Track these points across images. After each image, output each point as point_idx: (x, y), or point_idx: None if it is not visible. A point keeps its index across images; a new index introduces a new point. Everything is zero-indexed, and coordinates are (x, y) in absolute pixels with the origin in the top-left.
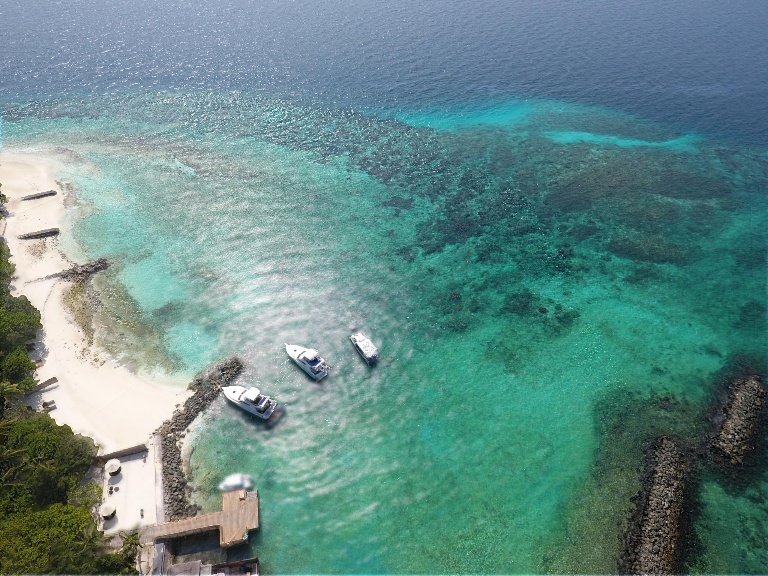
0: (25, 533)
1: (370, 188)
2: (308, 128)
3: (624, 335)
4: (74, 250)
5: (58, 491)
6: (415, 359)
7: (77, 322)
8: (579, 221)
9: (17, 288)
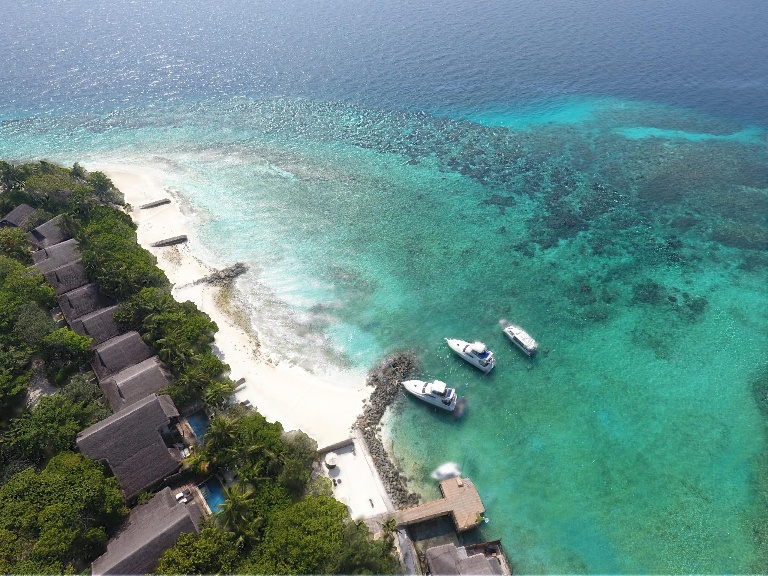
0: (300, 522)
1: (467, 187)
2: (387, 131)
3: (756, 320)
4: (208, 256)
5: (300, 484)
6: (569, 349)
7: (238, 325)
8: (676, 213)
9: (171, 294)
